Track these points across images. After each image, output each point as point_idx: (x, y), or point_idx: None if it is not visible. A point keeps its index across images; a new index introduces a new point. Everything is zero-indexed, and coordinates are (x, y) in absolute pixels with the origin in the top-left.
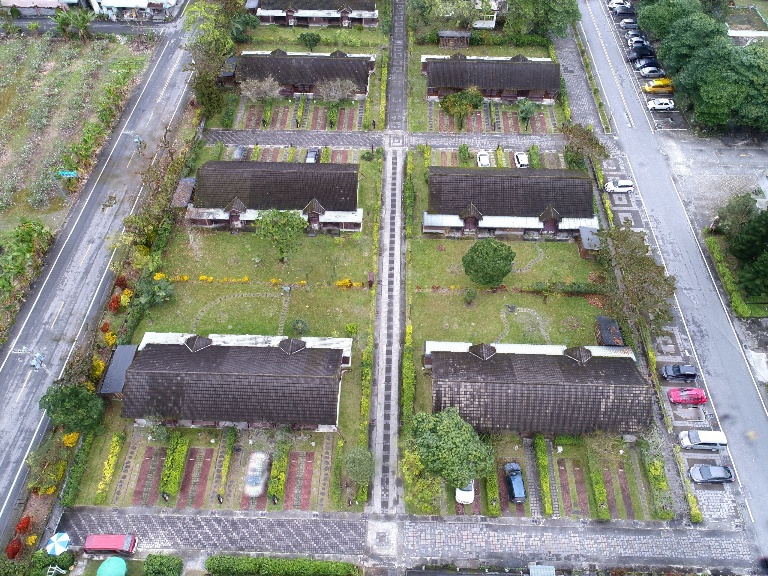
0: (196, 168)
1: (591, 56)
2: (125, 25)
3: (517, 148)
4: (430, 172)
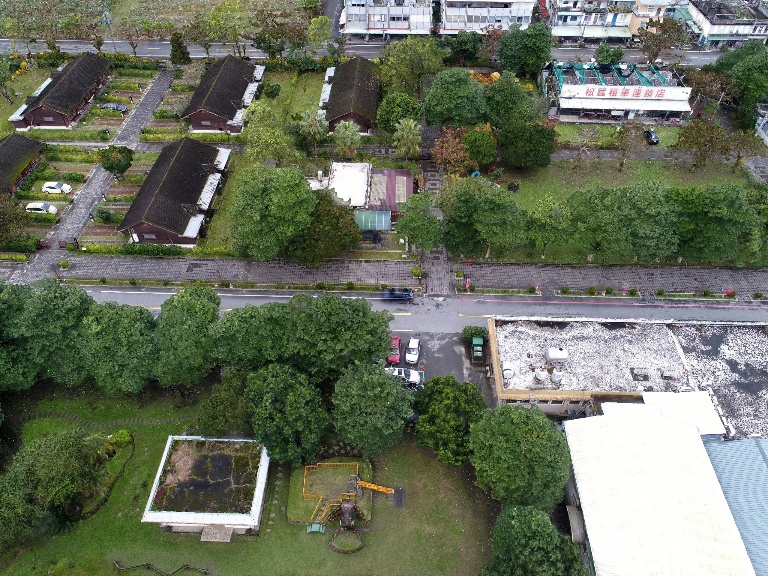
0: (125, 67)
1: (219, 293)
2: (333, 28)
3: (68, 213)
4: (20, 135)
